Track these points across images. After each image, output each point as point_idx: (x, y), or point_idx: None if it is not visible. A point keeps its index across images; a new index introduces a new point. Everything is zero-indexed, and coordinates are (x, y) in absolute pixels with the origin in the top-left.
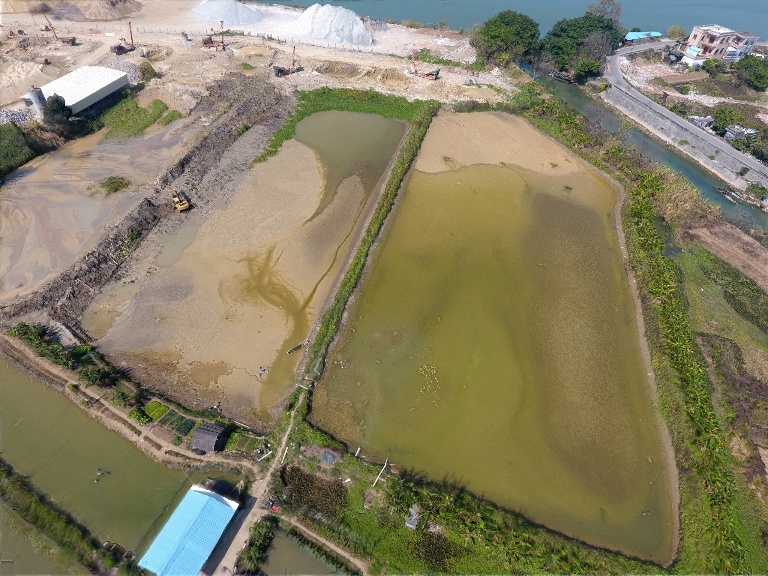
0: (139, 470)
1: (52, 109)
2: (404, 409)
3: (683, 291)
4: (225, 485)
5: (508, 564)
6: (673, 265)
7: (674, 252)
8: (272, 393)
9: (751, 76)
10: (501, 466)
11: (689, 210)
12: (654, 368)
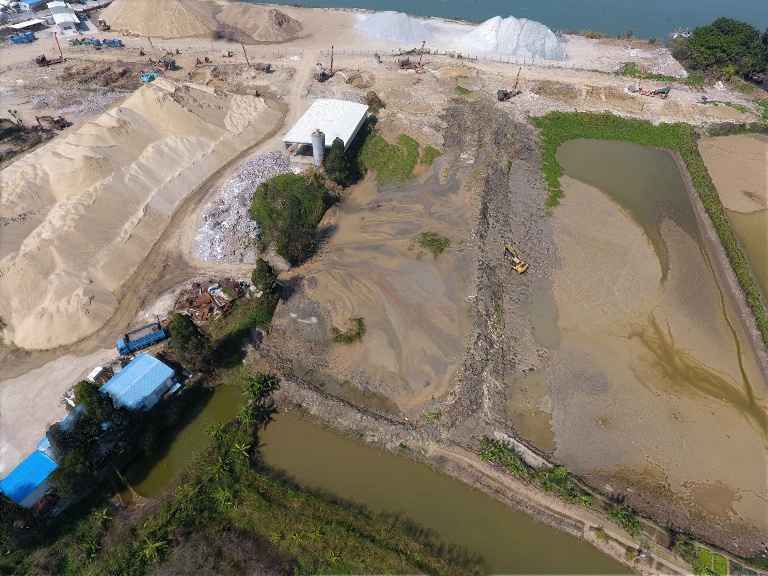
0: None
1: (341, 156)
2: None
3: None
4: None
5: None
6: None
7: None
8: None
9: None
10: None
11: None
12: None
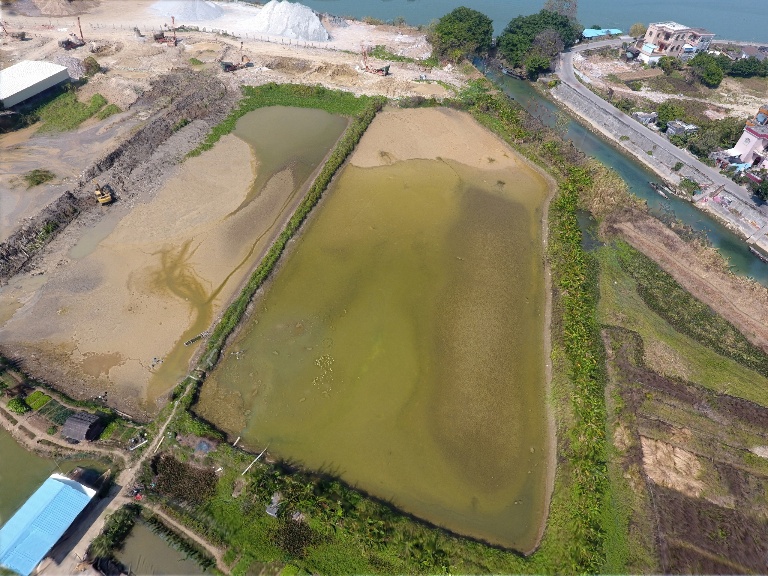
0: (9, 459)
1: None
2: (294, 400)
3: (597, 284)
4: (93, 474)
5: (364, 551)
6: (591, 258)
7: (595, 246)
8: (162, 383)
9: (703, 73)
10: (383, 456)
11: (614, 204)
12: (552, 359)
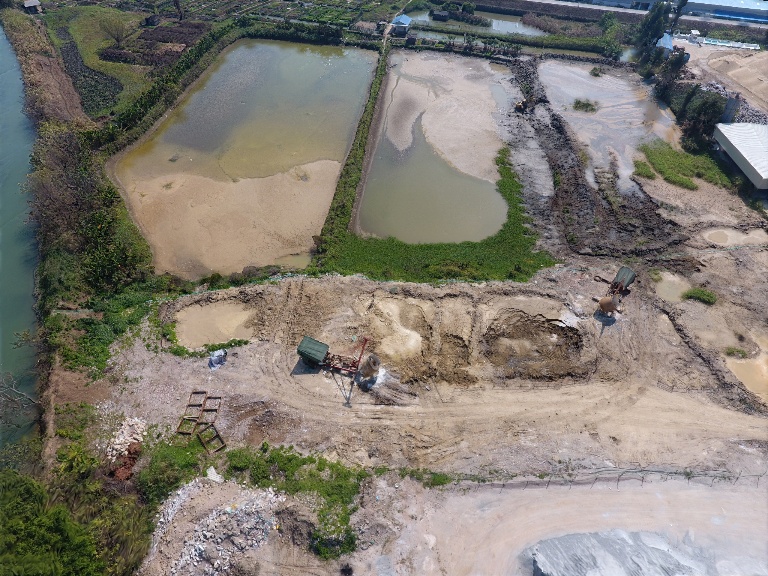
0: None
1: None
2: None
3: None
4: None
5: None
6: None
7: None
8: (398, 56)
9: None
10: None
11: None
12: None
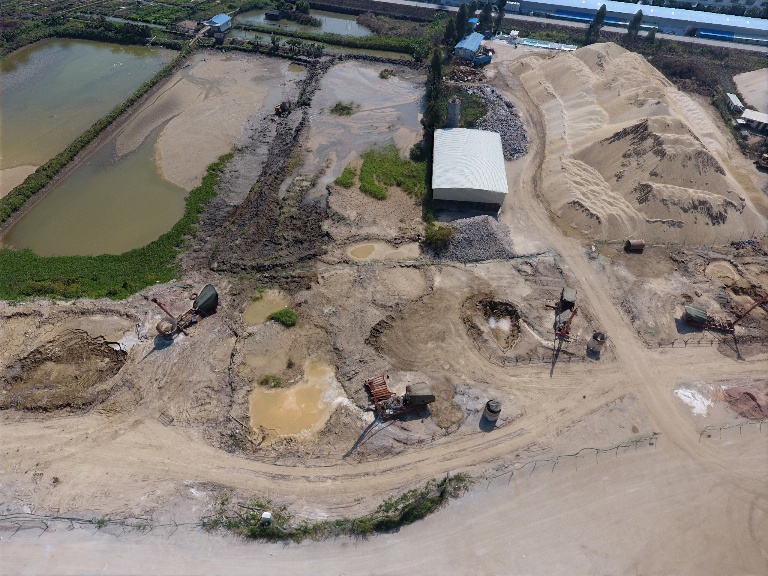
0: None
1: None
2: None
3: None
4: None
5: None
6: None
7: None
8: (199, 56)
9: None
10: None
11: None
12: None
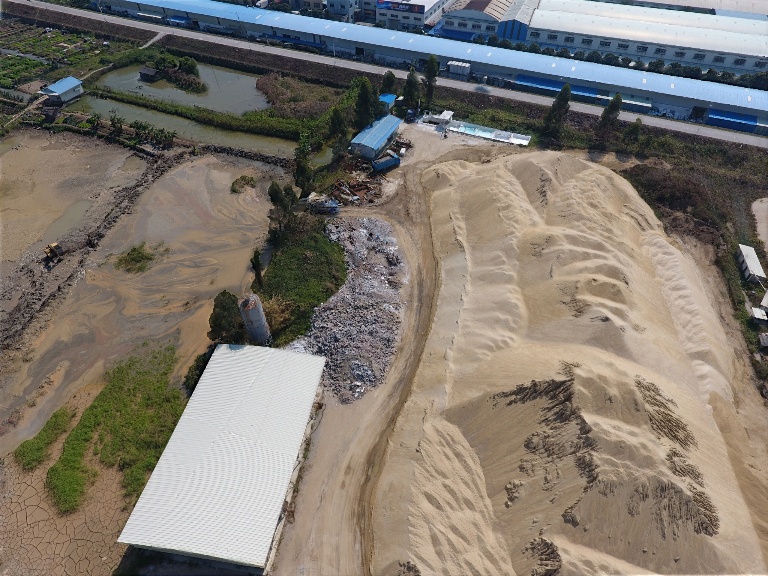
0: None
1: None
2: None
3: None
4: None
5: None
6: None
7: None
8: (15, 141)
9: None
10: None
11: None
12: None
